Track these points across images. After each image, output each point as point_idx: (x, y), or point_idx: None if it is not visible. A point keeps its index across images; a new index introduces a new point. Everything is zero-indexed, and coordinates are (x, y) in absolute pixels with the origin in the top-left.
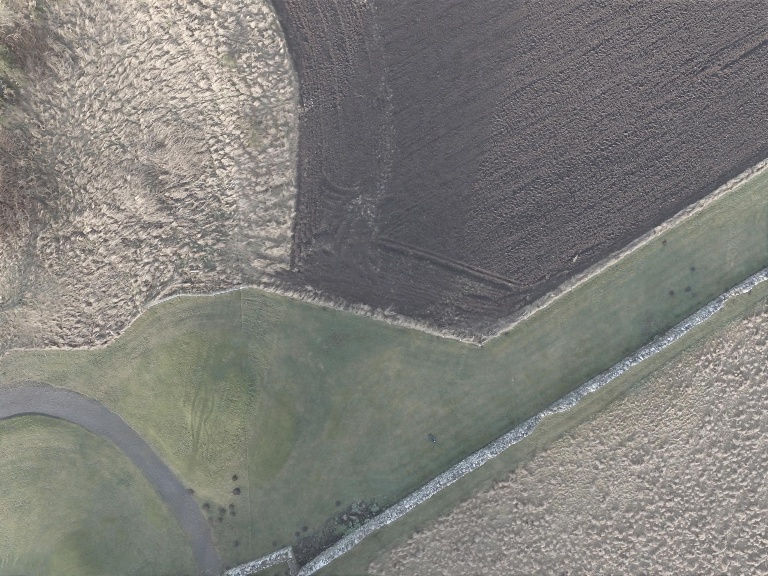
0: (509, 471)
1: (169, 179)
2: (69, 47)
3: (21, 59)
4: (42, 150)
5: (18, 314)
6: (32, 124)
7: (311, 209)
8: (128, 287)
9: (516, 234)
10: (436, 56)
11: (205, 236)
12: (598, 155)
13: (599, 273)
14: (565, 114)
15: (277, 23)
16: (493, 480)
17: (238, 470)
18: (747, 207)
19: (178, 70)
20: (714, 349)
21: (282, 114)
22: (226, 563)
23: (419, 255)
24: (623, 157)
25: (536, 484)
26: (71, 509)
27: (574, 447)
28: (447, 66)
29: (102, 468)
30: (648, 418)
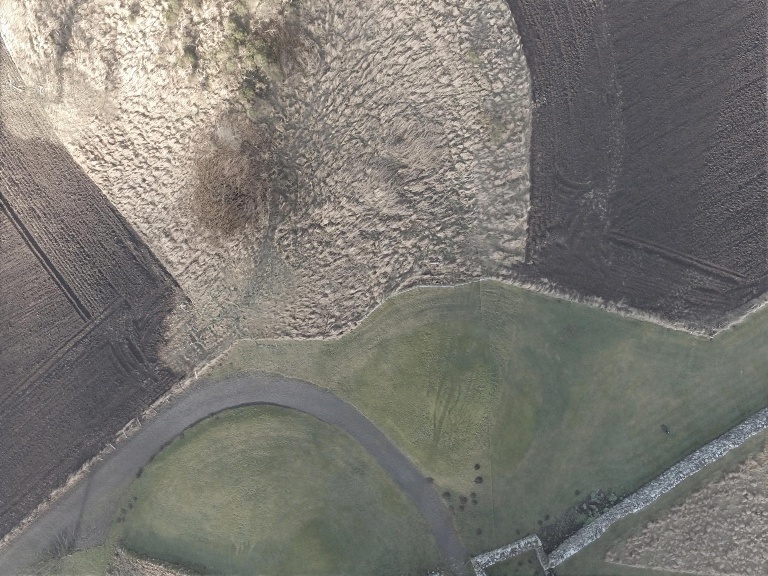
0: (739, 462)
1: (408, 173)
2: (317, 43)
3: (275, 54)
4: (285, 143)
5: (252, 305)
6: (277, 118)
7: (545, 203)
8: (366, 278)
9: (743, 228)
10: (663, 53)
11: (445, 229)
12: None
13: None
14: None
15: (513, 20)
16: (723, 471)
17: (481, 459)
18: None
19: (420, 66)
20: None
21: (520, 109)
22: (470, 551)
23: (648, 249)
24: None
25: (765, 475)
26: (308, 497)
27: None
28: (673, 63)
29: (337, 457)
30: None
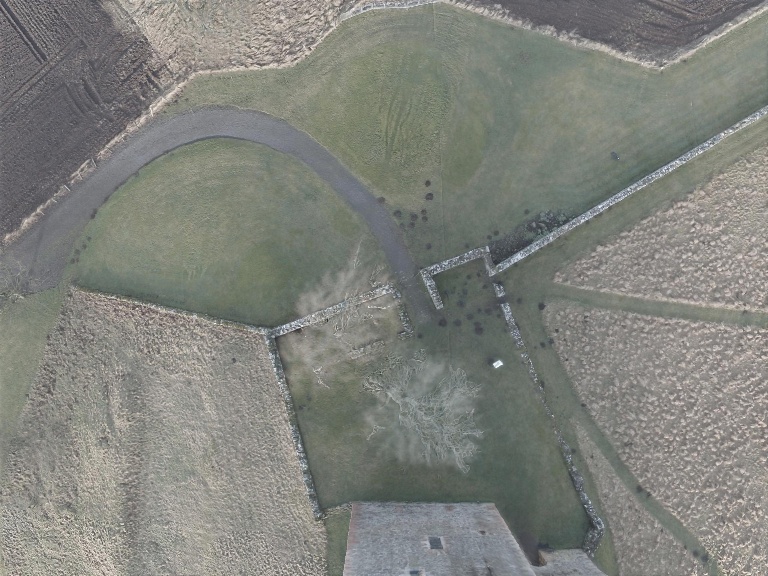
0: (687, 192)
1: None
2: None
3: None
4: None
5: (207, 34)
6: None
7: None
8: (321, 3)
9: None
10: None
11: None
12: None
13: None
14: None
15: None
16: (672, 200)
17: (431, 175)
18: None
19: None
20: None
21: None
22: (420, 264)
23: None
24: None
25: (712, 206)
26: (261, 219)
27: (749, 171)
28: None
29: (290, 183)
30: None
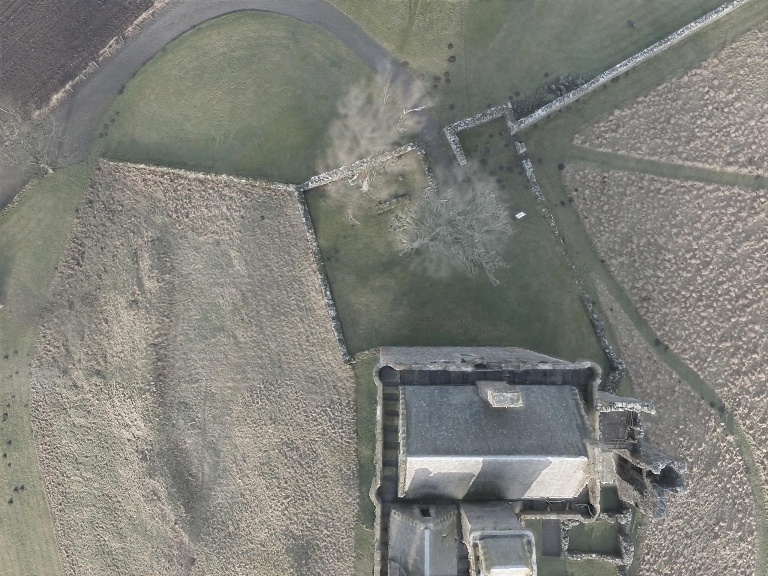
0: (701, 60)
1: None
2: None
3: None
4: None
5: None
6: None
7: None
8: None
9: None
10: None
11: None
12: None
13: None
14: None
15: None
16: (686, 68)
17: (454, 38)
18: None
19: None
20: None
21: None
22: (443, 123)
23: None
24: None
25: (726, 74)
26: (287, 85)
27: (761, 41)
28: None
29: (315, 51)
30: None
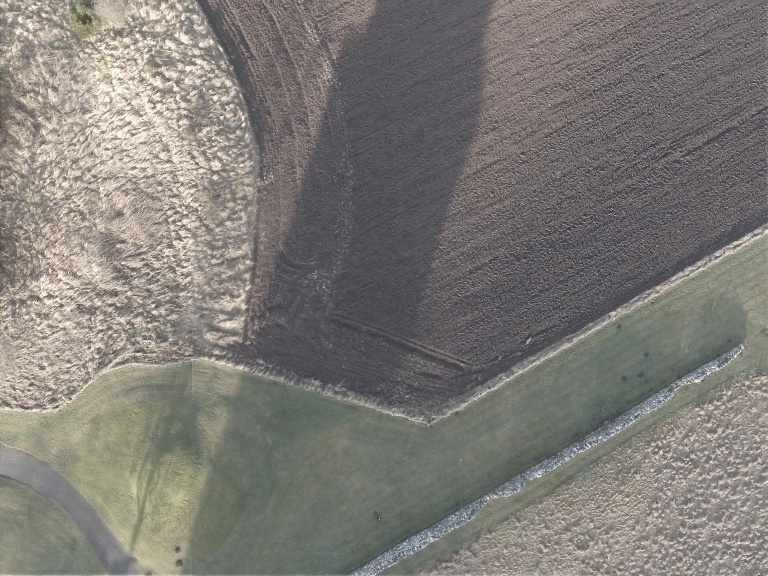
0: (453, 551)
1: (126, 248)
2: (31, 115)
3: None
4: (1, 214)
5: None
6: None
7: (266, 282)
8: (81, 353)
9: (470, 314)
10: (398, 133)
11: (159, 306)
12: (556, 238)
13: (552, 356)
14: (525, 195)
15: (240, 96)
16: (437, 560)
17: (181, 542)
18: (704, 294)
19: (139, 141)
20: (665, 436)
21: (241, 188)
22: None
23: (372, 332)
24: (581, 241)
25: (480, 565)
26: (16, 571)
27: (519, 530)
28: (409, 144)
29: (49, 531)
30: (595, 503)
